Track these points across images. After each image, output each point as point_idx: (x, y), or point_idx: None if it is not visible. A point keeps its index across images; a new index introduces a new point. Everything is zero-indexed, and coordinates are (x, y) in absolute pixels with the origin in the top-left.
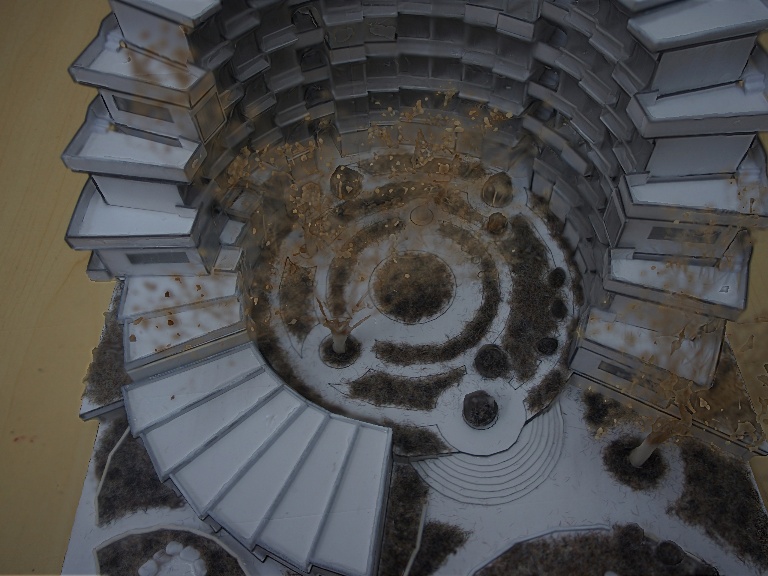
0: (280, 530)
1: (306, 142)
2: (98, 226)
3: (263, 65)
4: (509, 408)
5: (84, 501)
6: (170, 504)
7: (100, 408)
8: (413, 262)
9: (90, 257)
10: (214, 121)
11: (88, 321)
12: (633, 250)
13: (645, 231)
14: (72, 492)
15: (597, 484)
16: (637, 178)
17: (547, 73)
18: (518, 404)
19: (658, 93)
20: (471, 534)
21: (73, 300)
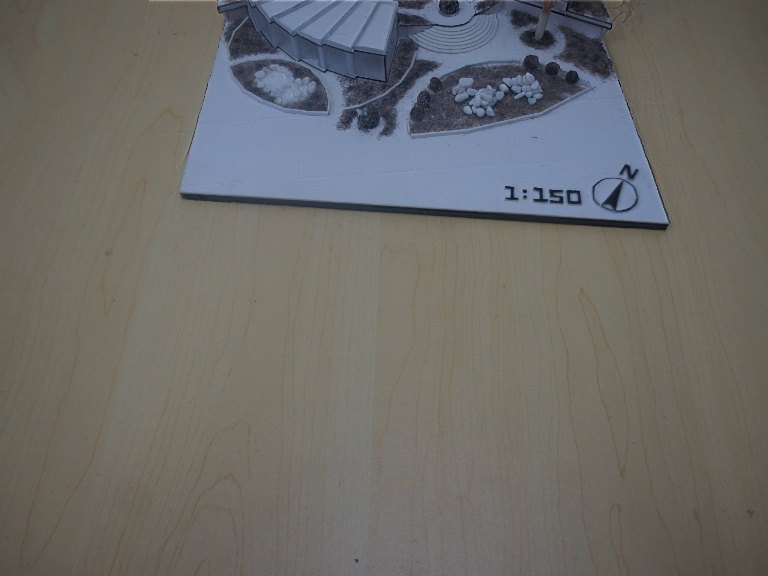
0: (336, 38)
1: None
2: None
3: None
4: (466, 9)
5: (220, 51)
6: (270, 51)
7: (229, 4)
8: None
9: None
10: None
11: None
12: None
13: None
14: (210, 54)
15: (515, 47)
16: None
17: None
18: (471, 7)
19: None
20: (442, 64)
21: None
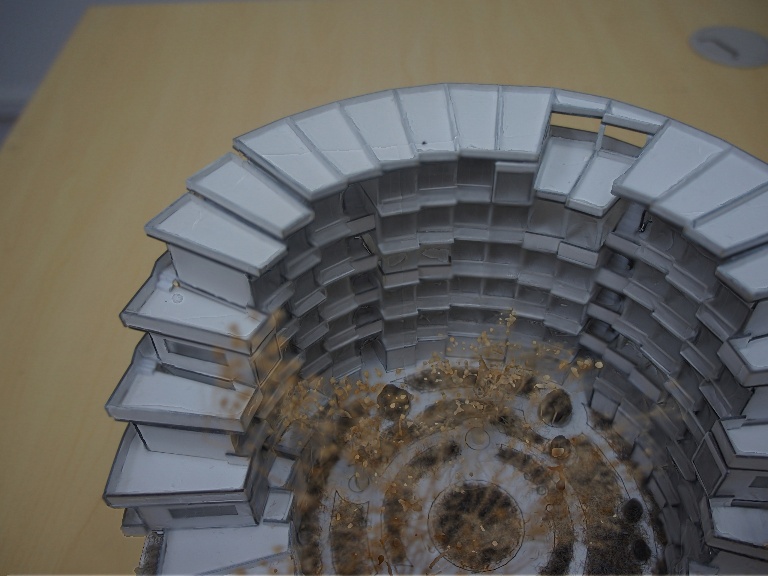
0: None
1: (353, 362)
2: (138, 478)
3: (319, 298)
4: None
5: None
6: None
7: None
8: (474, 494)
9: (125, 509)
10: (270, 361)
11: (112, 571)
12: (732, 498)
13: (747, 480)
14: None
15: None
16: (733, 423)
17: (604, 292)
18: None
19: (750, 336)
20: None
21: (95, 545)
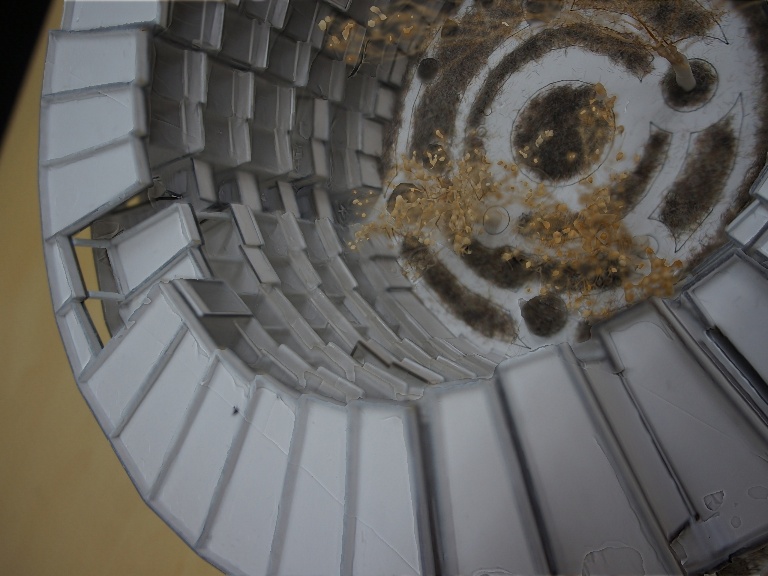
0: None
1: None
2: None
3: None
4: None
5: None
6: None
7: None
8: (541, 162)
9: None
10: None
11: None
12: None
13: None
14: None
15: None
16: None
17: None
18: None
19: None
20: None
21: None
